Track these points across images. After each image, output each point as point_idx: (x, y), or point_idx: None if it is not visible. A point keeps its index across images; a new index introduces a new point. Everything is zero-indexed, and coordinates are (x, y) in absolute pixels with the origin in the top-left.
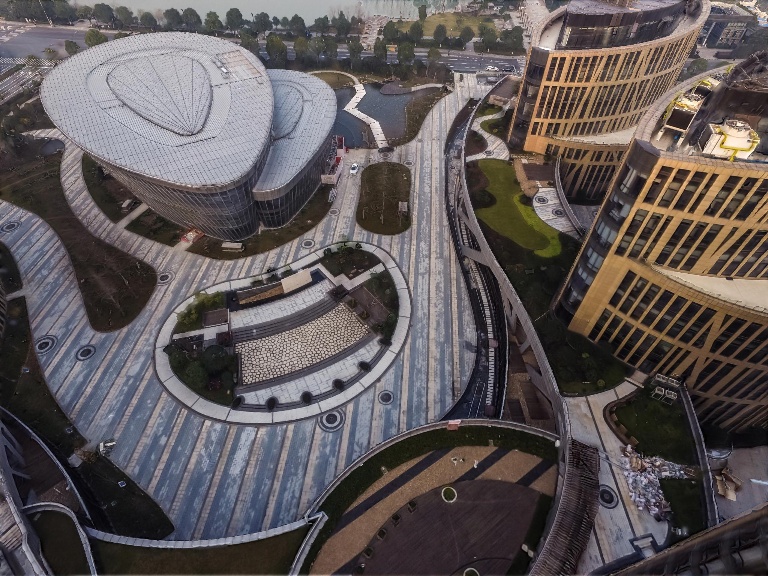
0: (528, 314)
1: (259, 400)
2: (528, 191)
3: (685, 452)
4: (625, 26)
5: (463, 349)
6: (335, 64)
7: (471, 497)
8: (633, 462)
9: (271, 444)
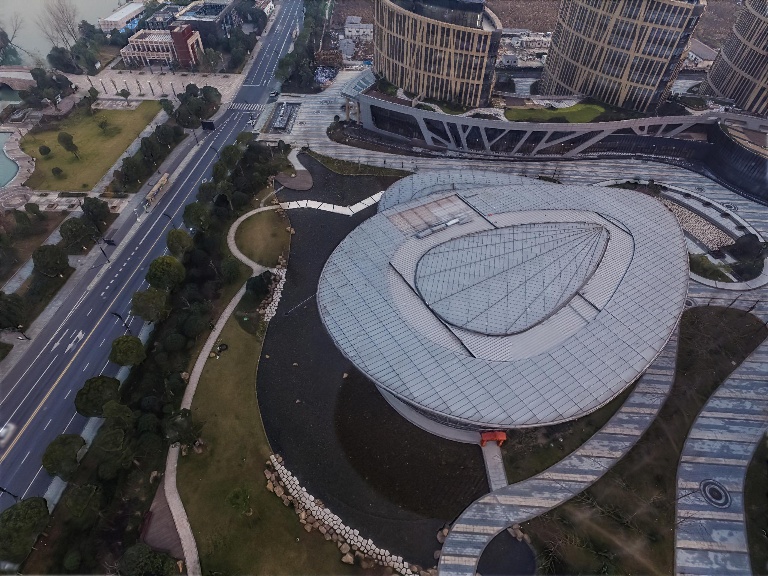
0: None
1: (743, 234)
2: (540, 107)
3: (701, 99)
4: None
5: (648, 164)
6: (223, 221)
7: (762, 143)
8: (717, 107)
9: (763, 226)
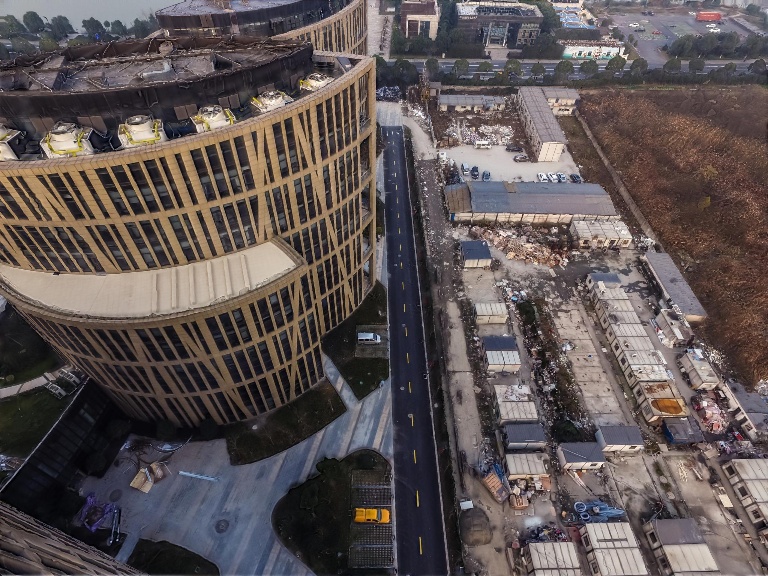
0: (4, 311)
1: None
2: None
3: None
4: (224, 27)
5: None
6: None
7: None
8: None
9: None
